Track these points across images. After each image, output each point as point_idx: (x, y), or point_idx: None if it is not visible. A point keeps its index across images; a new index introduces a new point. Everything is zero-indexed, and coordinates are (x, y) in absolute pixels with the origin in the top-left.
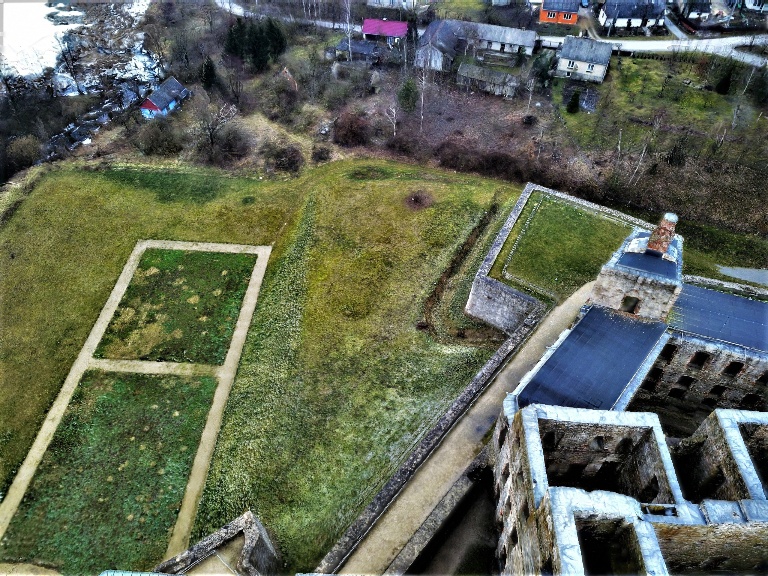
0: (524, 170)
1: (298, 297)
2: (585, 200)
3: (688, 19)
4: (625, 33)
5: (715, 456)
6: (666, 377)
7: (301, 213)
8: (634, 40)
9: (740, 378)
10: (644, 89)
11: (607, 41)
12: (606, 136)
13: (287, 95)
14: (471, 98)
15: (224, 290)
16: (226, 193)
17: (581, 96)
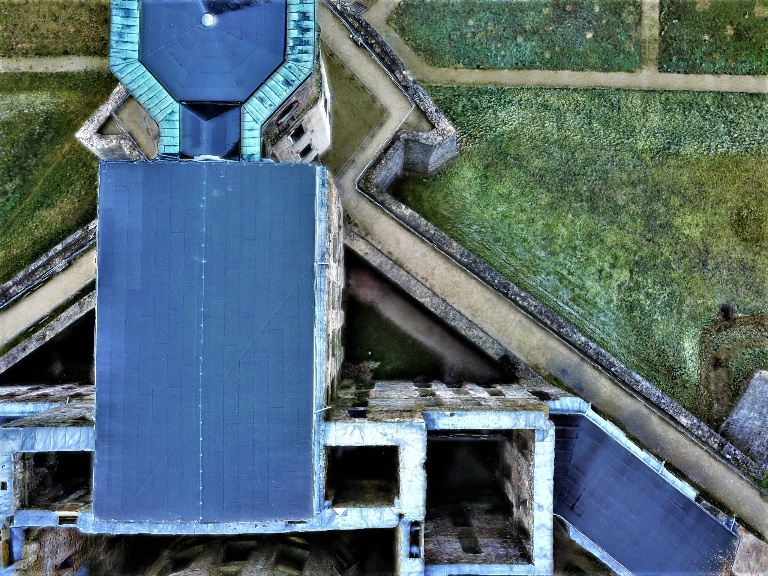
0: None
1: None
2: None
3: None
4: None
5: None
6: None
7: None
8: None
9: None
10: None
11: None
12: None
13: None
14: None
15: None
16: None
17: None
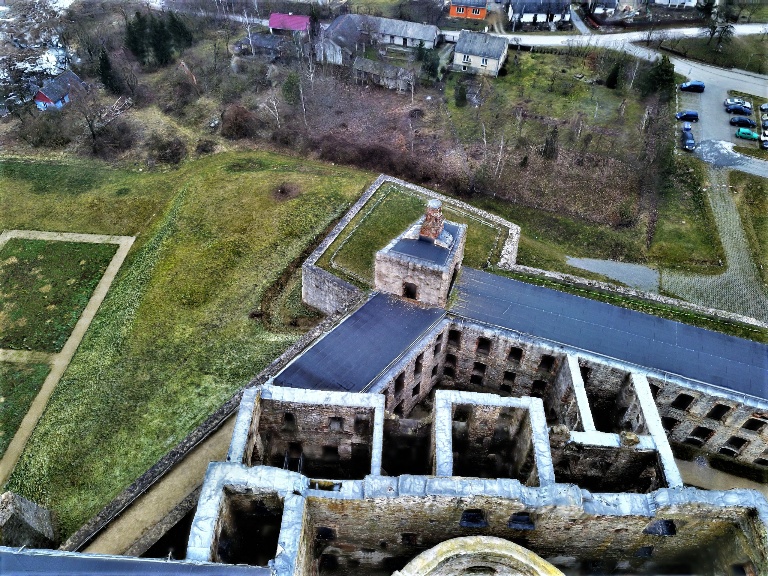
0: (397, 162)
1: (141, 286)
2: (433, 191)
3: (594, 14)
4: (530, 28)
5: (433, 436)
6: (461, 363)
7: (171, 204)
8: (538, 35)
9: (523, 364)
10: (536, 83)
11: (509, 36)
12: (488, 129)
13: (181, 88)
14: (365, 92)
15: (78, 279)
16: (102, 184)
17: (473, 90)
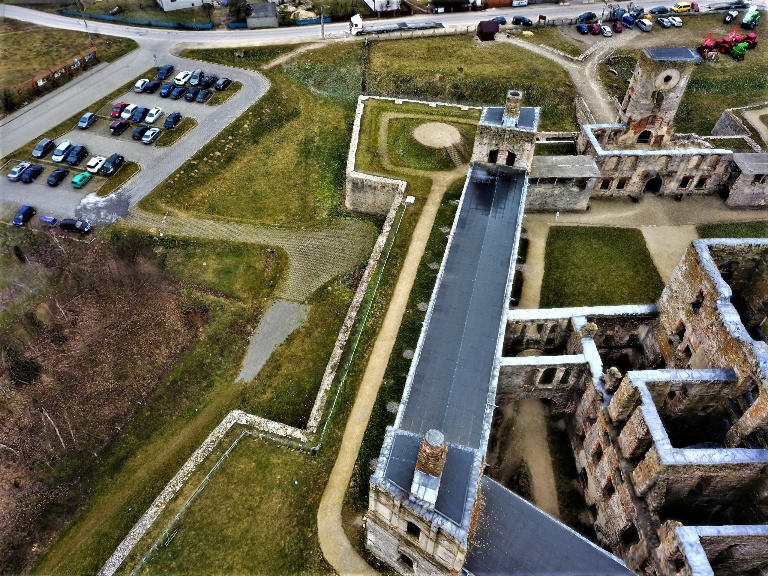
0: None
1: None
2: (133, 527)
3: None
4: None
5: (692, 478)
6: None
7: None
8: None
9: None
10: None
11: None
12: None
13: None
14: None
15: None
16: None
17: None
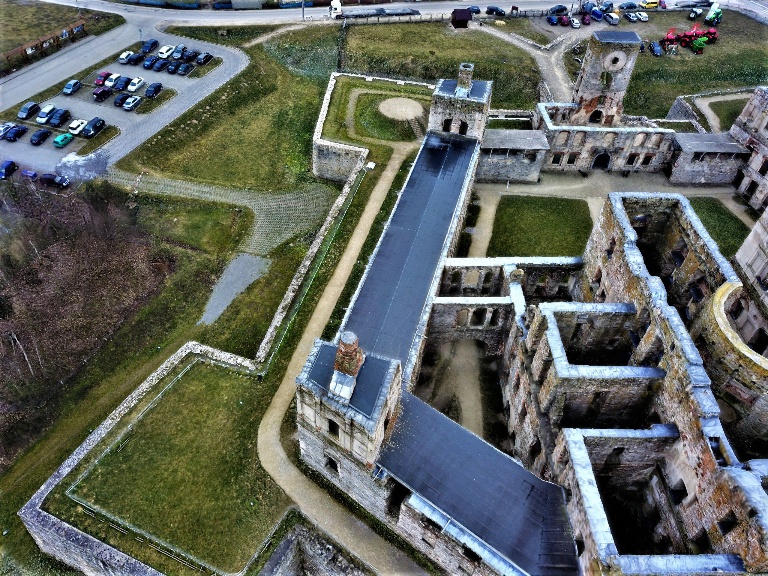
0: None
1: None
2: (89, 436)
3: None
4: None
5: (586, 393)
6: None
7: None
8: None
9: None
10: None
11: None
12: None
13: None
14: None
15: None
16: None
17: None
